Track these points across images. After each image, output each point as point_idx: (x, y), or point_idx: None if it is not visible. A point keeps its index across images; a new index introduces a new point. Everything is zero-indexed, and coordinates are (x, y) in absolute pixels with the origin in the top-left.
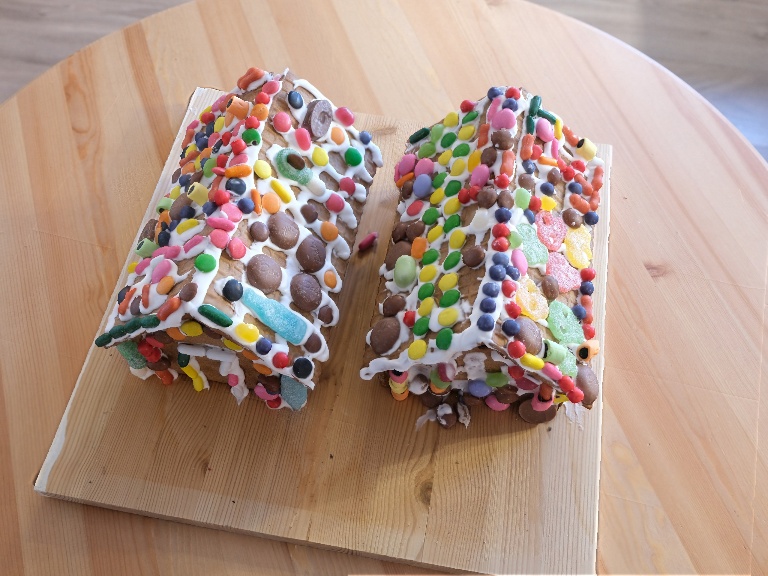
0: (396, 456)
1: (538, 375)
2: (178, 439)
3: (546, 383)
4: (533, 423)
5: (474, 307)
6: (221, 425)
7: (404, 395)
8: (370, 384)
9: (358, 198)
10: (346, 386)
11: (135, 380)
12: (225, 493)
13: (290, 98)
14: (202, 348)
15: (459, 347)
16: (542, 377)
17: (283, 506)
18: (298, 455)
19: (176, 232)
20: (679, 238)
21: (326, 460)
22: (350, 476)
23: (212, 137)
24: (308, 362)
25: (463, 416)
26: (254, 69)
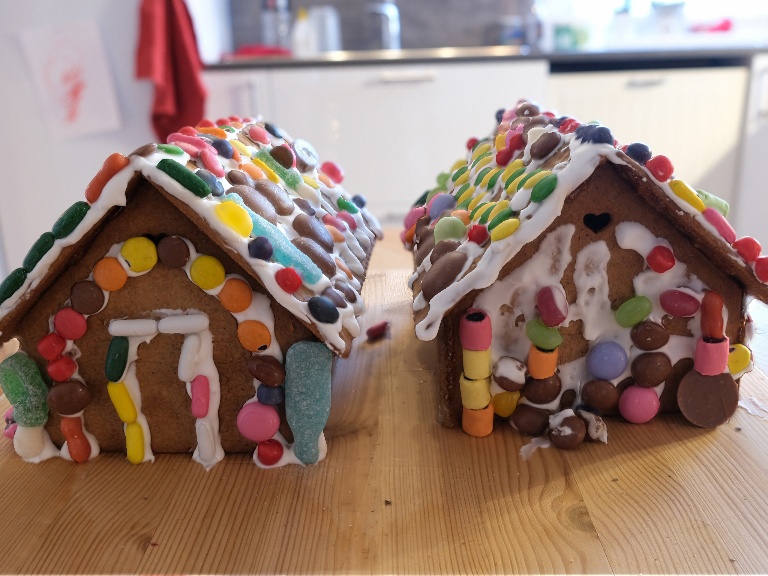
0: (503, 488)
1: (701, 226)
2: (92, 517)
3: (716, 247)
4: (707, 427)
5: None
6: (176, 494)
7: (488, 414)
8: (426, 429)
9: (361, 240)
10: (388, 435)
11: (19, 465)
12: (186, 570)
13: (267, 125)
14: (151, 319)
15: (572, 176)
16: (708, 231)
17: (309, 571)
18: (325, 509)
19: None
20: (764, 310)
21: (379, 507)
22: (430, 519)
23: None
24: (331, 303)
25: (594, 420)
26: None
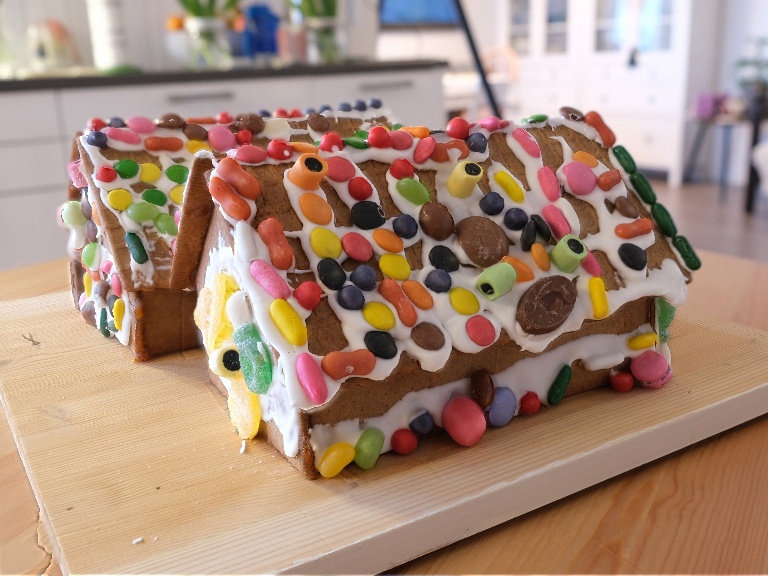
0: None
1: None
2: None
3: None
4: None
5: (365, 117)
6: None
7: None
8: None
9: None
10: None
11: None
12: None
13: None
14: None
15: None
16: None
17: None
18: None
19: (524, 205)
20: None
21: None
22: None
23: (357, 240)
24: None
25: None
26: (218, 177)
